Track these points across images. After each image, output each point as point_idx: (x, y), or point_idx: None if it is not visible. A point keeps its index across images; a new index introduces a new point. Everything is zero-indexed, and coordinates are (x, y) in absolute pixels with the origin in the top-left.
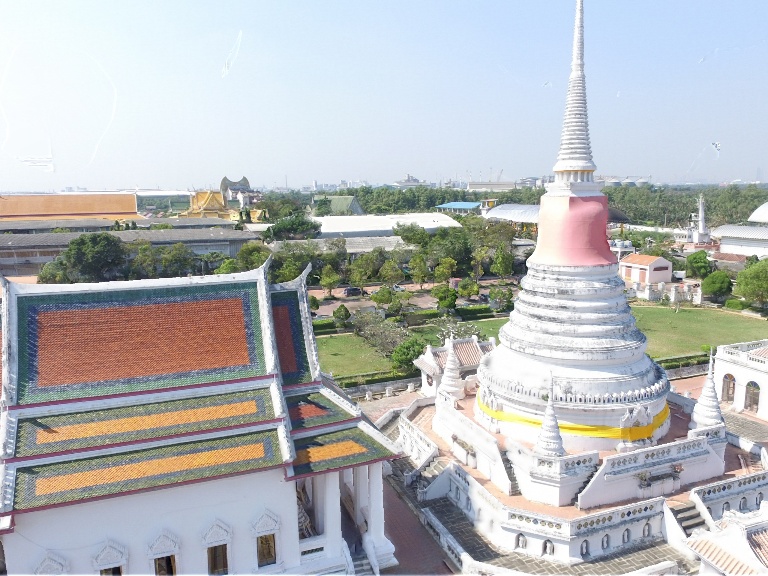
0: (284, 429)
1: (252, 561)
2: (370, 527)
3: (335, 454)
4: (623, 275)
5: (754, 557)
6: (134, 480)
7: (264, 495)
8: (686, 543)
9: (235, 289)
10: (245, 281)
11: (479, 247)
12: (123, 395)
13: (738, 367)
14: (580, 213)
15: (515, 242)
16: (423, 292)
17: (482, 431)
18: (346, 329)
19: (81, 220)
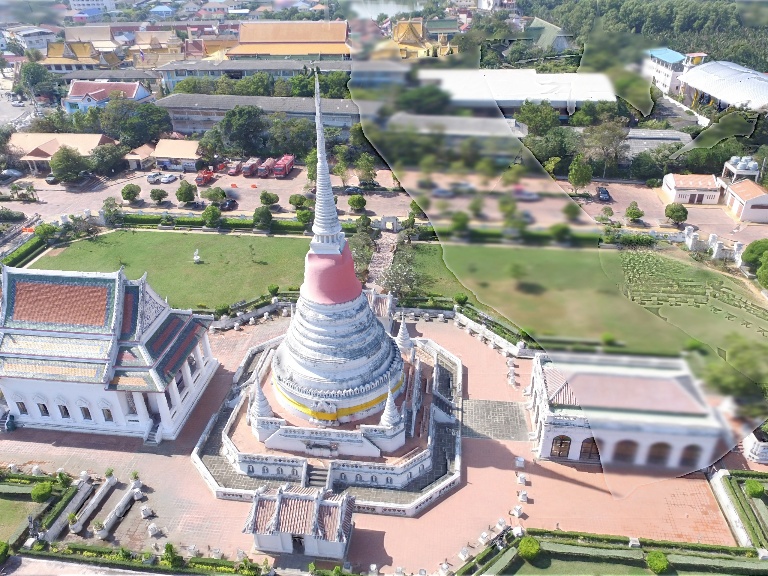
0: (107, 365)
1: (102, 418)
2: (161, 419)
3: (131, 383)
4: (728, 202)
5: (253, 511)
6: (39, 374)
7: (101, 392)
8: (258, 489)
9: (105, 282)
10: (110, 278)
11: (573, 148)
12: (45, 331)
13: None
14: (314, 266)
15: (652, 133)
16: None
17: (255, 382)
18: None
19: (281, 62)
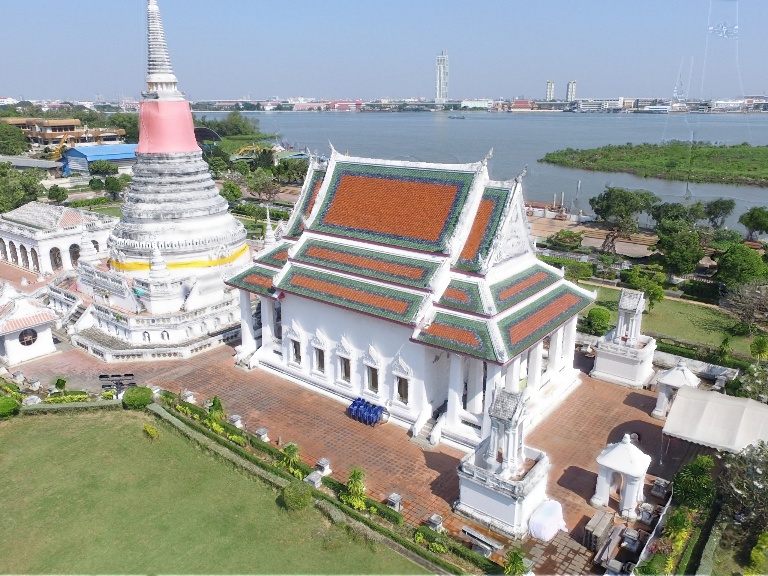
0: None
1: None
2: None
3: None
4: None
5: None
6: None
7: None
8: None
9: None
10: None
11: None
12: None
13: (60, 239)
14: None
15: None
16: None
17: None
18: None
19: None
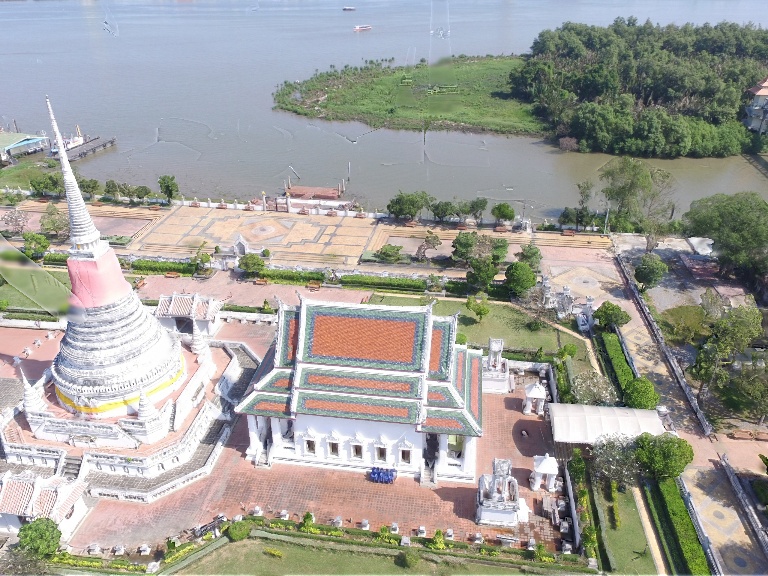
0: None
1: None
2: None
3: None
4: None
5: None
6: None
7: None
8: None
9: None
10: None
11: None
12: None
13: None
14: None
15: None
16: None
17: None
18: None
19: None
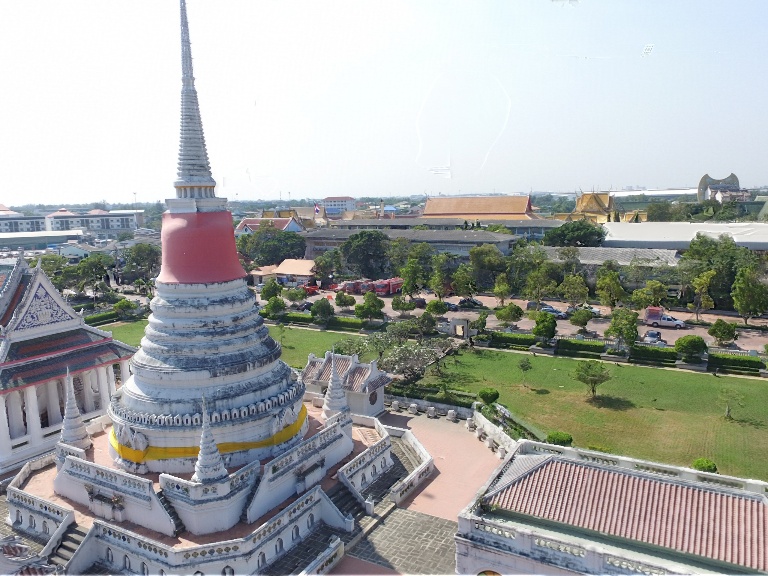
0: None
1: None
2: None
3: None
4: None
5: None
6: None
7: None
8: None
9: (7, 269)
10: None
11: None
12: None
13: None
14: (164, 229)
15: None
16: (611, 318)
17: None
18: (423, 336)
19: (445, 219)
